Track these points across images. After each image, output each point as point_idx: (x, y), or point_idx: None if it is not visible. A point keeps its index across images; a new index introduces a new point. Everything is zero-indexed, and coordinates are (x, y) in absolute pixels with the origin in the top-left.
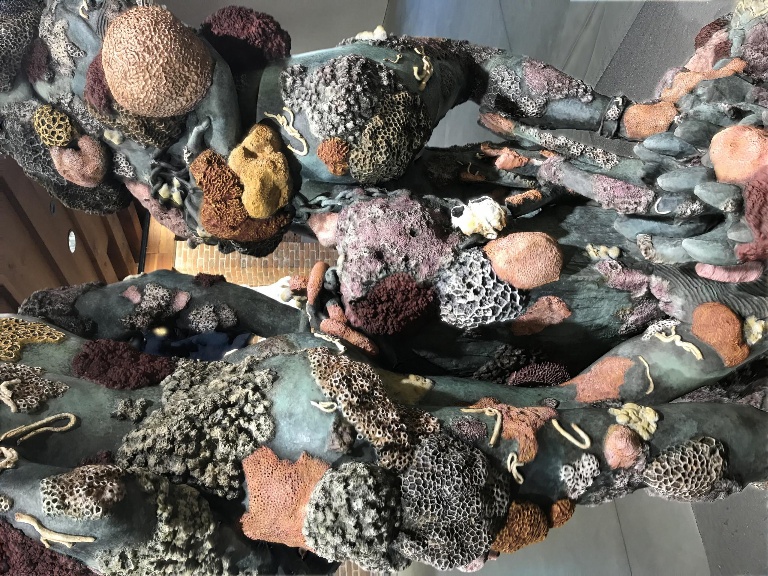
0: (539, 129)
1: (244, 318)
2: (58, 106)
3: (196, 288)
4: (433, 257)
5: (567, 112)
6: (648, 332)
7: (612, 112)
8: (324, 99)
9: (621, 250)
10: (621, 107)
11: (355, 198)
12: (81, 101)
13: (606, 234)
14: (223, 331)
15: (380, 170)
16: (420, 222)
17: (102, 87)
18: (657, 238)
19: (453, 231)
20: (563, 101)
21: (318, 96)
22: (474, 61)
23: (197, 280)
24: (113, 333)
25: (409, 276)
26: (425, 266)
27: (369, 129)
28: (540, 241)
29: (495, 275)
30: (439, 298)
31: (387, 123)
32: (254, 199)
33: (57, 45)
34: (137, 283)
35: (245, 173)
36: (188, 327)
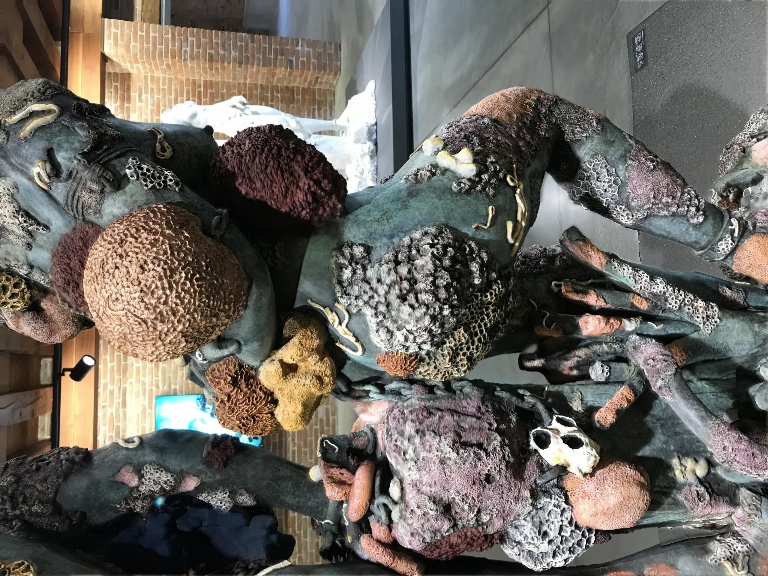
0: (559, 7)
1: (264, 500)
2: (8, 268)
3: (207, 471)
4: (509, 508)
5: (668, 230)
6: (717, 555)
7: (724, 245)
8: (397, 317)
9: (709, 464)
10: (736, 239)
11: (413, 395)
12: (44, 273)
13: (694, 435)
14: (239, 511)
15: (452, 377)
16: (499, 466)
17: (80, 294)
18: (767, 505)
19: (531, 456)
20: (667, 218)
21: (388, 307)
22: (563, 136)
23: (207, 459)
24: (105, 517)
25: (479, 532)
26: (499, 520)
27: (449, 347)
28: (634, 493)
29: (574, 521)
30: (505, 538)
31: (472, 333)
32: (292, 424)
33: (0, 205)
34: (132, 461)
35: (281, 391)
36: (195, 497)
